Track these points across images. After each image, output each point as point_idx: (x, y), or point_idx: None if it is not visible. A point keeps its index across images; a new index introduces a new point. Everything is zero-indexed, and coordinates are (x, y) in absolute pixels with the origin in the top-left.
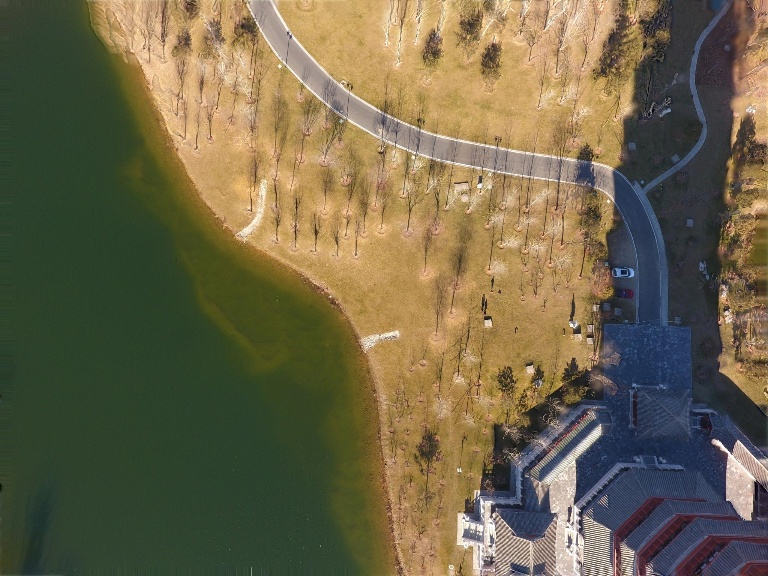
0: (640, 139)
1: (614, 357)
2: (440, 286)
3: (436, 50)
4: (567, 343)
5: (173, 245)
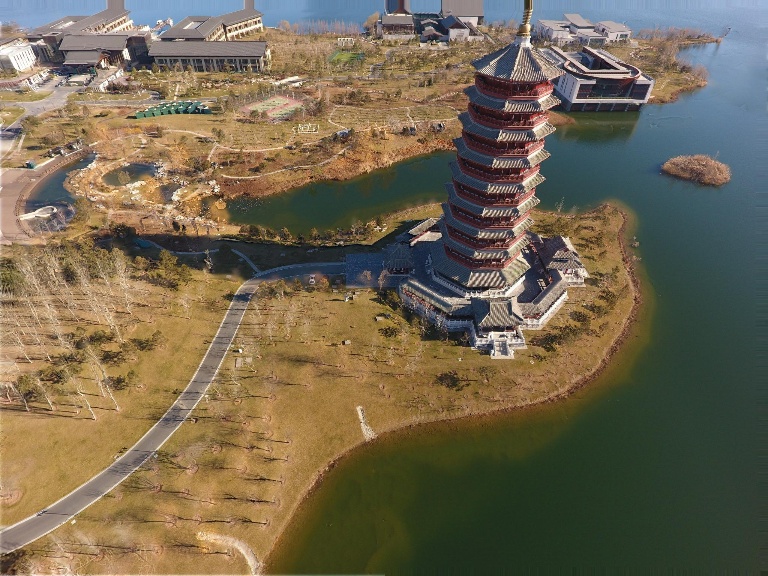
0: (225, 273)
1: (366, 273)
2: (319, 374)
3: (117, 381)
4: (359, 302)
5: None
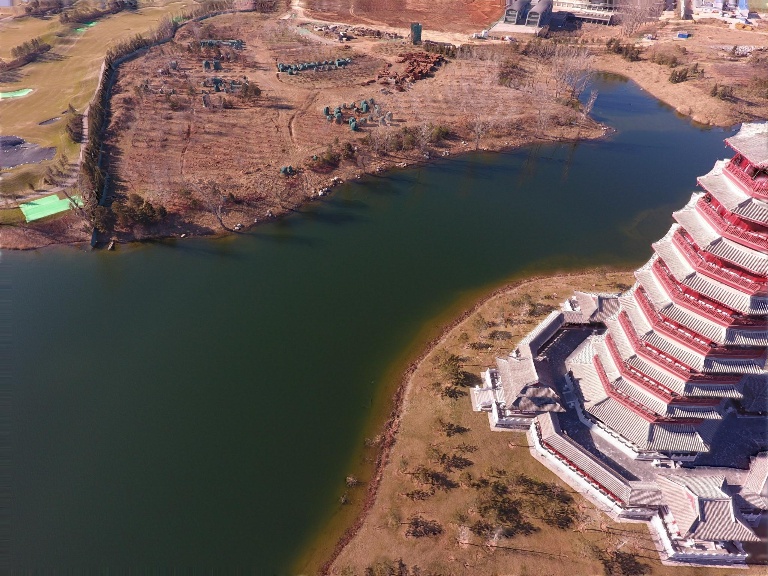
0: None
1: None
2: None
3: None
4: None
5: (669, 203)
